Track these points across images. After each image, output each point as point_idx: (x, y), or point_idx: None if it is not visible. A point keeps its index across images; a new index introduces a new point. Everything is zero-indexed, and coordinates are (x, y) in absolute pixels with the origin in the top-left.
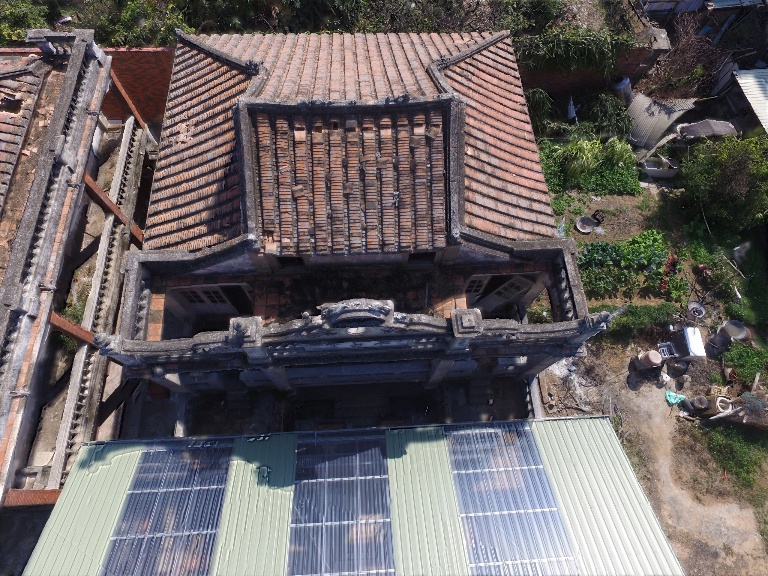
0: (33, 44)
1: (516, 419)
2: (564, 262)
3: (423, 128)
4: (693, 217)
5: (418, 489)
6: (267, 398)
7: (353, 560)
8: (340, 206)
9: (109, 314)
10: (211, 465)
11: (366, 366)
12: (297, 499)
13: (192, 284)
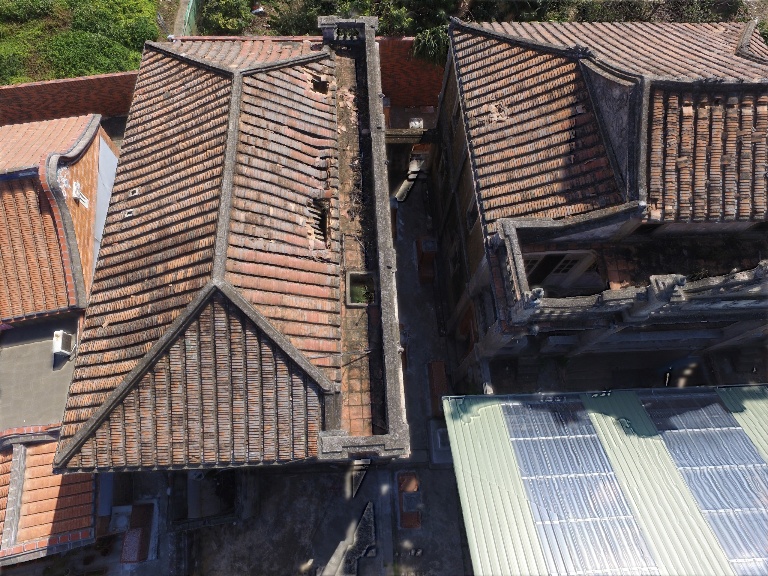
0: (234, 33)
1: None
2: None
3: None
4: None
5: None
6: (549, 364)
7: (753, 498)
8: (718, 176)
9: None
10: (572, 417)
11: (662, 332)
12: (669, 446)
13: (546, 250)
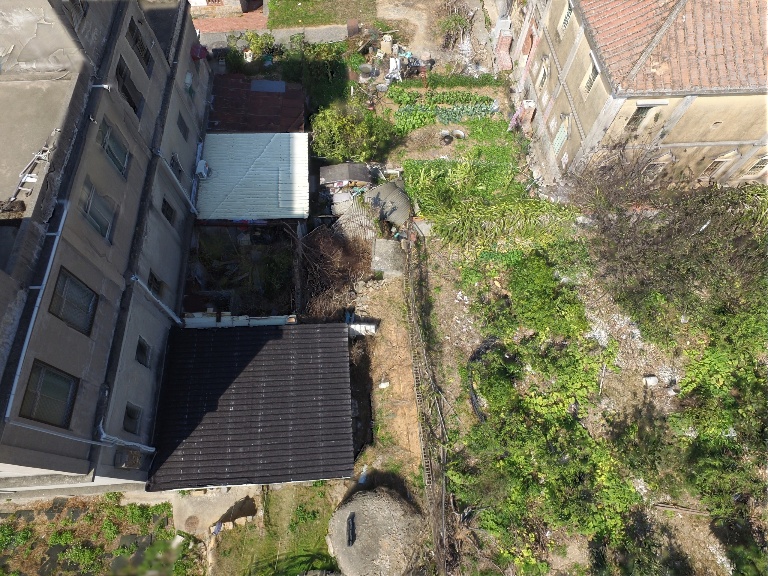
0: None
1: None
2: None
3: None
4: None
5: None
6: None
7: None
8: None
9: None
10: None
11: None
12: None
13: None
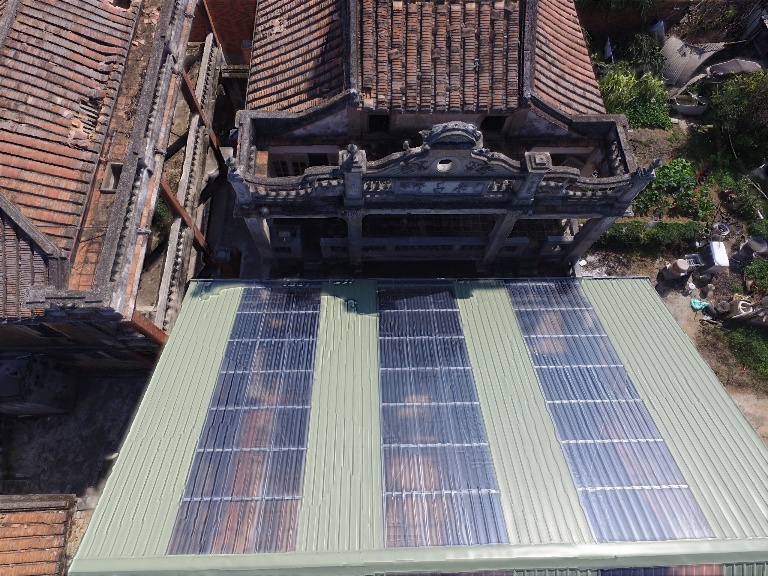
0: None
1: None
2: (617, 132)
3: (502, 3)
4: (720, 148)
5: (486, 319)
6: (338, 272)
7: (435, 361)
8: (429, 69)
9: (195, 200)
10: (305, 298)
11: (431, 238)
12: (382, 322)
13: (291, 145)
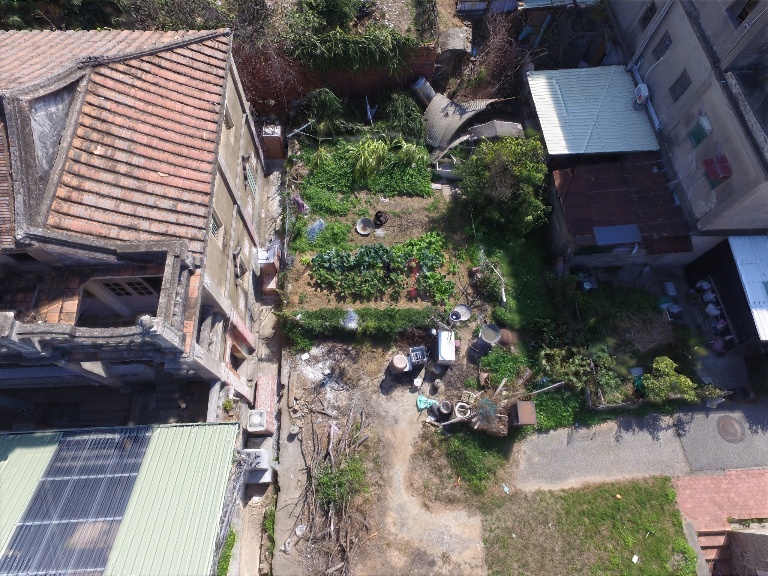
0: None
1: (141, 425)
2: (165, 265)
3: None
4: (475, 219)
5: None
6: None
7: None
8: None
9: None
10: None
11: (25, 369)
12: None
13: None
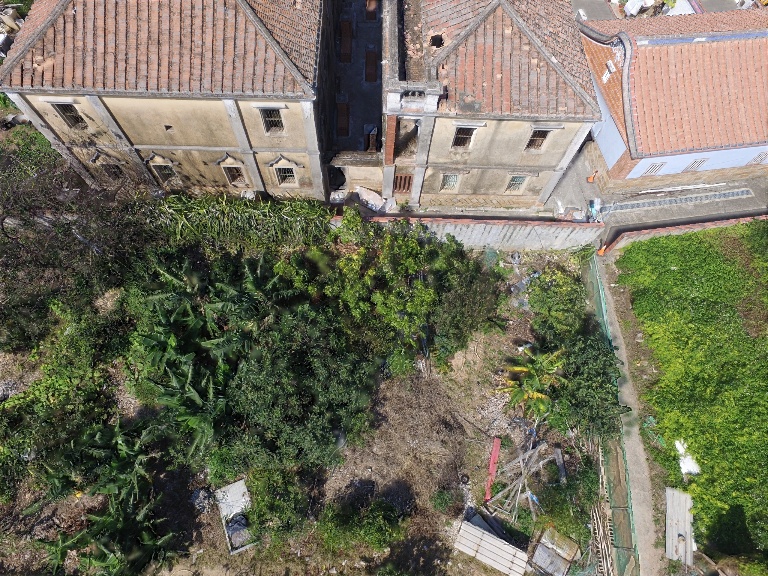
0: None
1: None
2: None
3: None
4: None
5: None
6: None
7: None
8: None
9: None
10: None
11: None
12: None
13: None
